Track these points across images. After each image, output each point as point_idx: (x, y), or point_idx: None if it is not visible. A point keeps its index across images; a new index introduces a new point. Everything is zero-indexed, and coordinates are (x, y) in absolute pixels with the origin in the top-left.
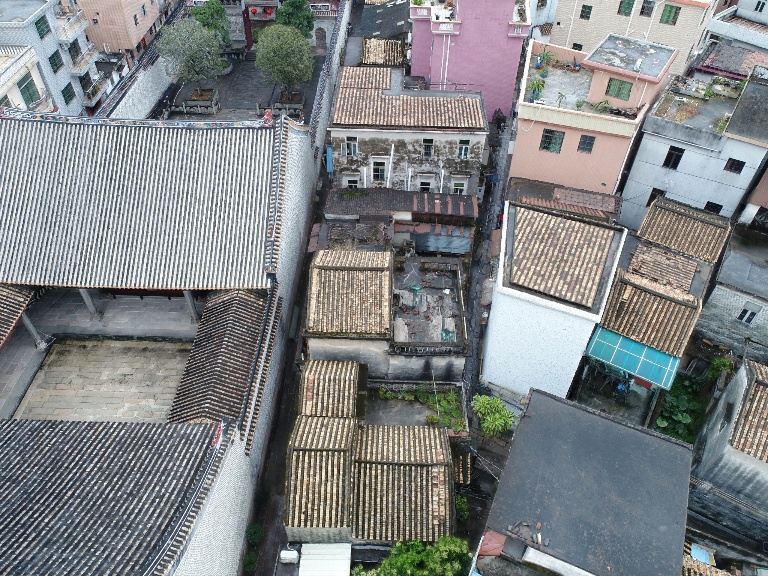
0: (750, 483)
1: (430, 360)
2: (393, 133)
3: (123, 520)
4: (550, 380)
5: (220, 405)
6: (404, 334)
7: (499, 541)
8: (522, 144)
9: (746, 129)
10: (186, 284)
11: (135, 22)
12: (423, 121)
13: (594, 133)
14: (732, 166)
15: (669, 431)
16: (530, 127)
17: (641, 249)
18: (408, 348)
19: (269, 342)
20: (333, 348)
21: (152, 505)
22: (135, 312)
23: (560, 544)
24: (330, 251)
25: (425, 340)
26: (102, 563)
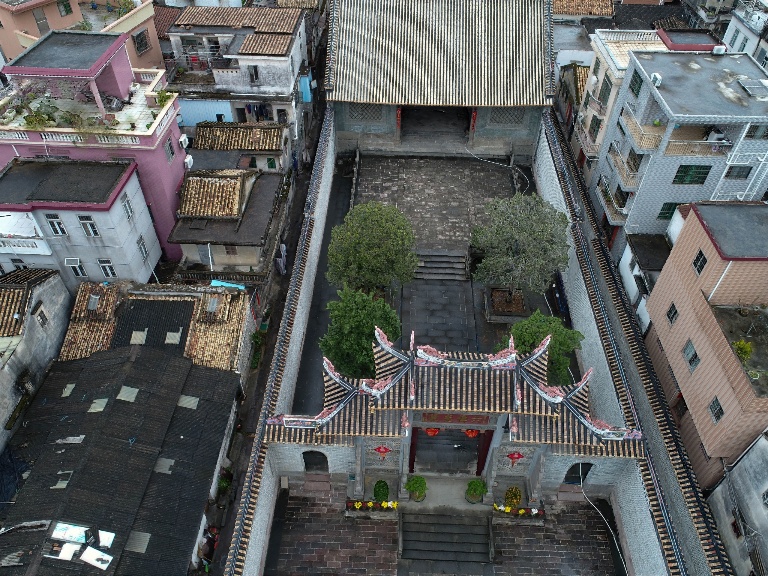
0: None
1: None
2: None
3: None
4: None
5: None
6: None
7: None
8: None
9: None
10: None
11: (671, 312)
12: (232, 10)
13: None
14: None
15: None
16: None
17: None
18: None
19: None
20: None
21: None
22: None
23: None
24: (312, 7)
25: None
26: None
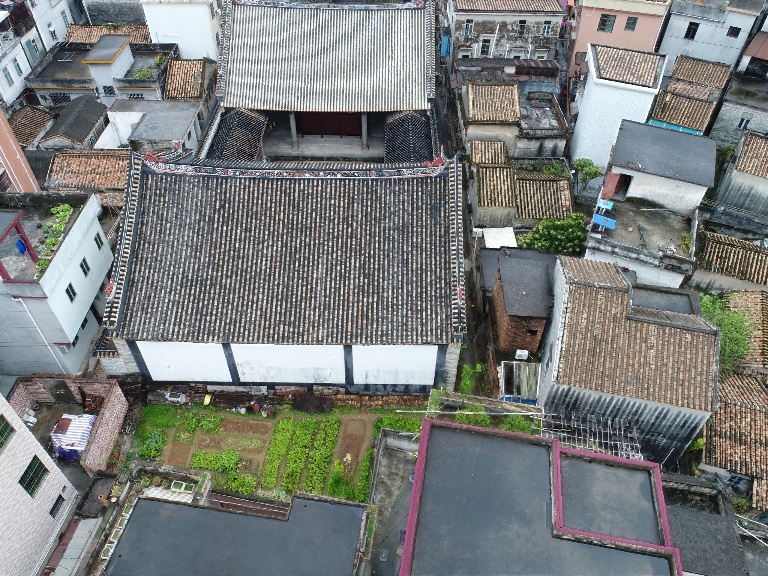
0: (748, 198)
1: (543, 143)
2: (499, 16)
3: None
4: None
5: None
6: None
7: (614, 183)
8: (585, 27)
9: (741, 5)
10: (374, 108)
11: None
12: (519, 8)
13: (637, 14)
14: (732, 32)
15: None
16: (592, 13)
17: (673, 82)
18: (530, 134)
19: None
20: (482, 134)
21: None
22: (320, 145)
23: (651, 169)
24: None
25: None
26: None
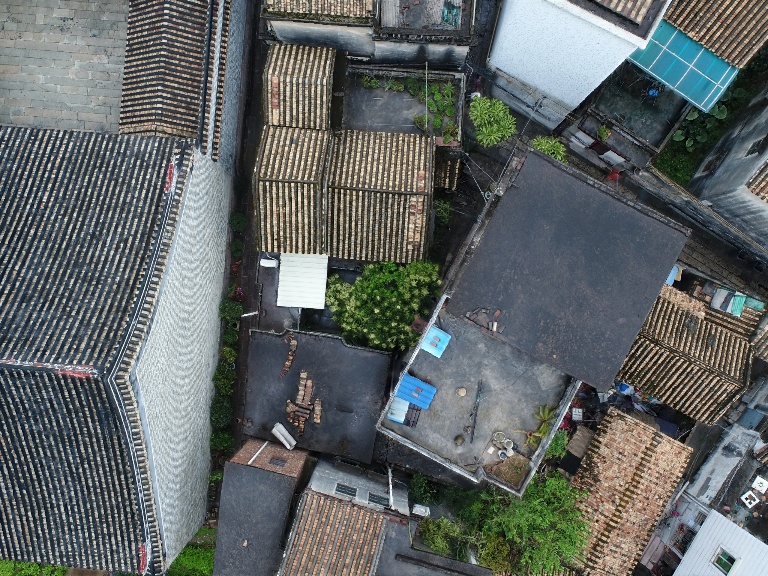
0: (752, 214)
1: (425, 46)
2: None
3: (91, 271)
4: (568, 83)
5: (175, 104)
6: (394, 9)
7: None
8: None
9: None
10: None
11: None
12: None
13: None
14: None
15: (696, 126)
16: None
17: None
18: None
19: (224, 3)
20: (303, 28)
21: (117, 252)
22: None
23: (514, 332)
24: None
25: (421, 19)
26: (79, 328)
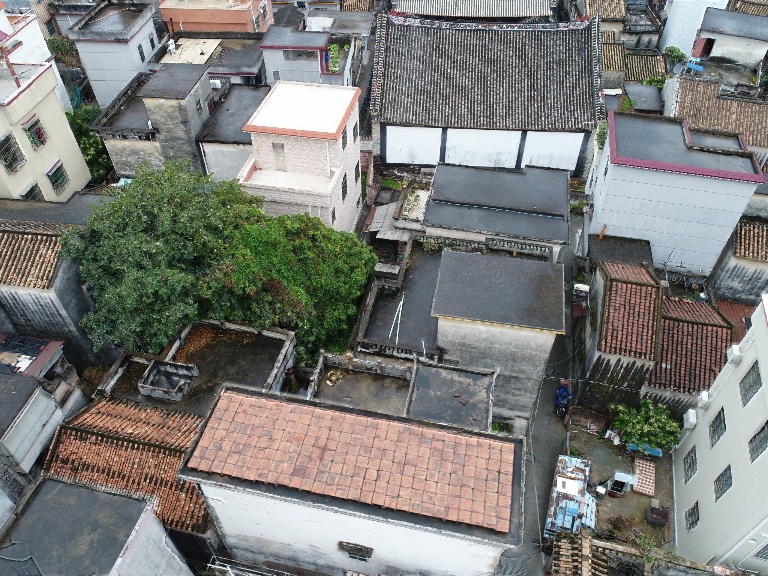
0: None
1: (641, 37)
2: None
3: None
4: None
5: None
6: None
7: (701, 46)
8: None
9: None
10: (509, 14)
11: None
12: None
13: None
14: None
15: None
16: None
17: None
18: None
19: None
20: None
21: None
22: None
23: (729, 32)
24: None
25: None
26: None
